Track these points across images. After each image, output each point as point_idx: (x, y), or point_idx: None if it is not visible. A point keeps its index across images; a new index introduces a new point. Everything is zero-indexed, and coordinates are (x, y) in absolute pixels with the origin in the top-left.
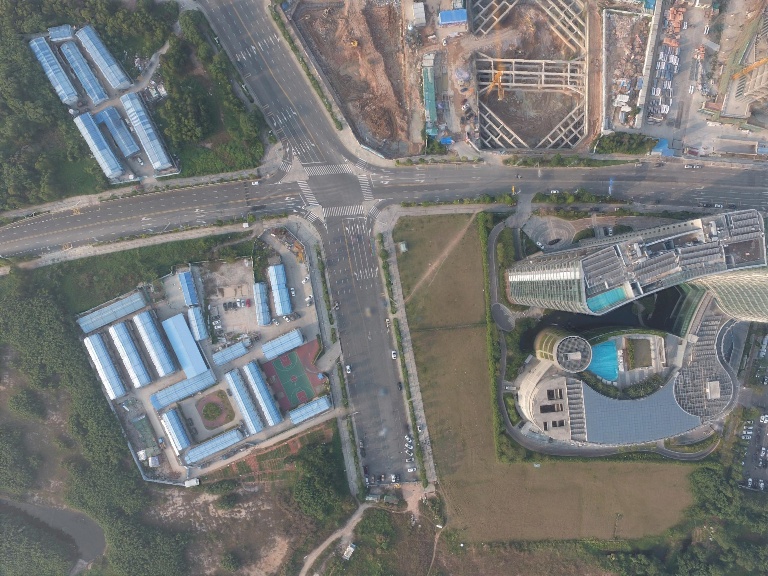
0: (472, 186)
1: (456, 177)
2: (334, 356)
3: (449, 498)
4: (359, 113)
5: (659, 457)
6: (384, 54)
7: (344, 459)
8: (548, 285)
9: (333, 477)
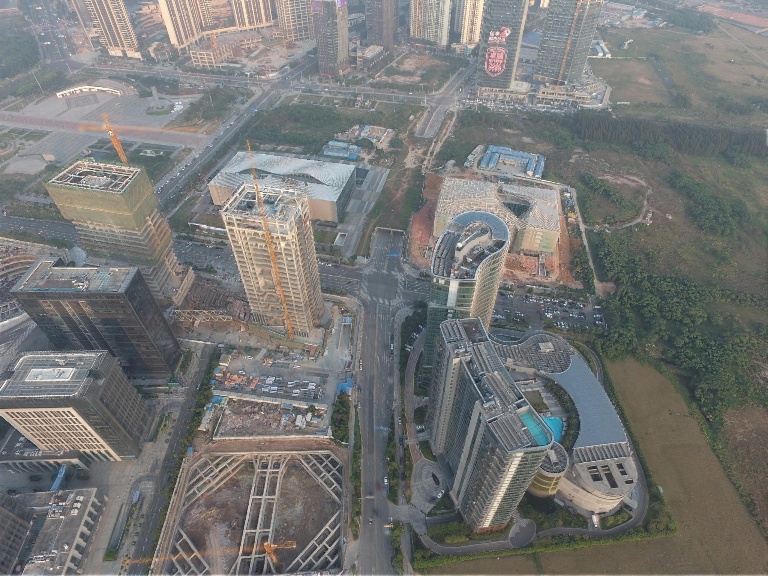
0: None
1: None
2: None
3: None
4: None
5: (607, 383)
6: None
7: None
8: (514, 483)
9: None
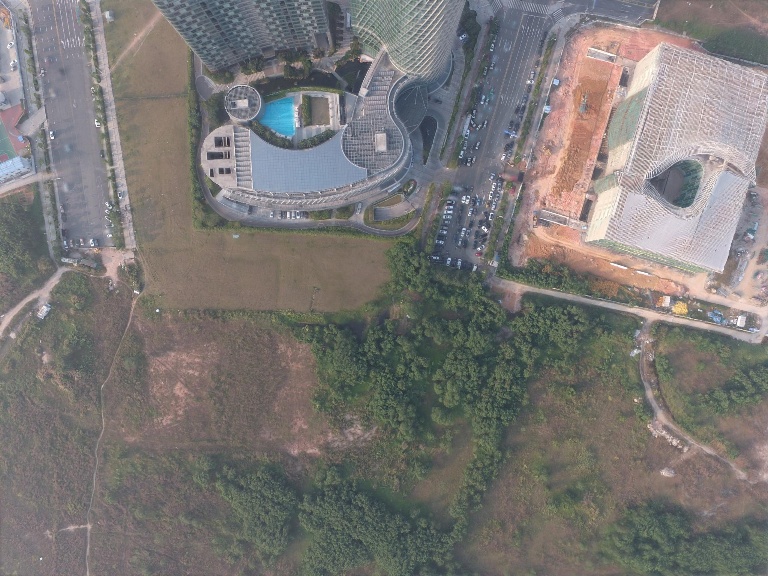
0: None
1: None
2: (38, 122)
3: (147, 265)
4: None
5: (354, 230)
6: None
7: (45, 223)
8: None
9: (29, 237)
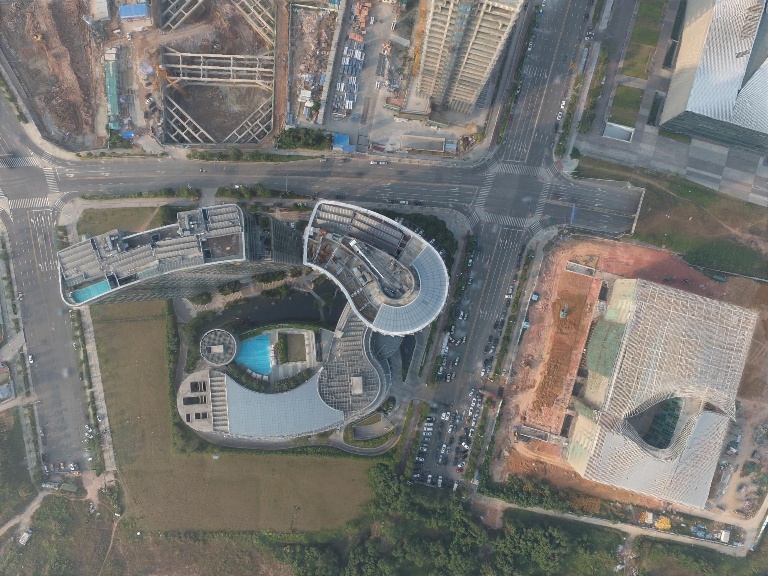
0: (156, 180)
1: (141, 171)
2: (17, 346)
3: (128, 487)
4: (45, 106)
5: (334, 451)
6: (72, 48)
7: (25, 447)
8: None
9: (10, 464)
